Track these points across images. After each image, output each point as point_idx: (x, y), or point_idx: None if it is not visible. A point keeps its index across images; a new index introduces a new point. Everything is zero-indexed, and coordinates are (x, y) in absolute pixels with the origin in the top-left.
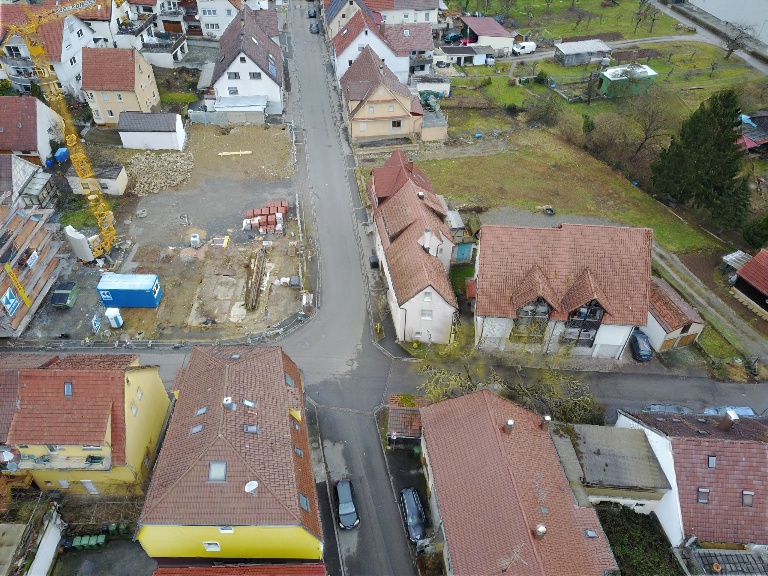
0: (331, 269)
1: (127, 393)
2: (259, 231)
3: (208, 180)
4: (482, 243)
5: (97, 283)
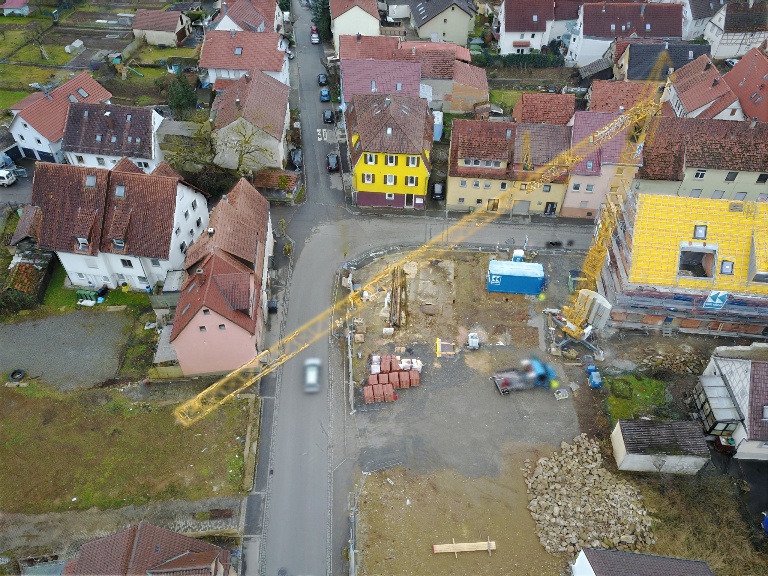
0: (320, 310)
1: None
2: (401, 359)
3: (494, 470)
4: None
5: (560, 306)
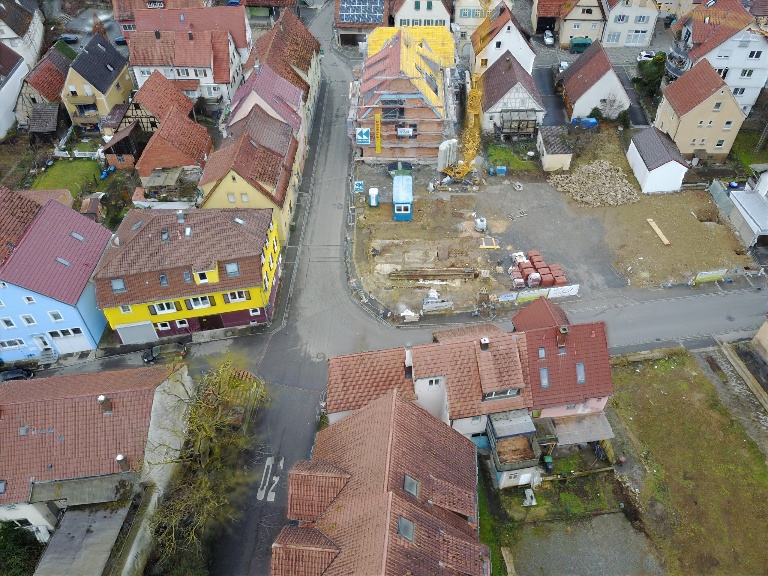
0: None
1: (227, 183)
2: None
3: (594, 220)
4: (377, 400)
5: (422, 184)
